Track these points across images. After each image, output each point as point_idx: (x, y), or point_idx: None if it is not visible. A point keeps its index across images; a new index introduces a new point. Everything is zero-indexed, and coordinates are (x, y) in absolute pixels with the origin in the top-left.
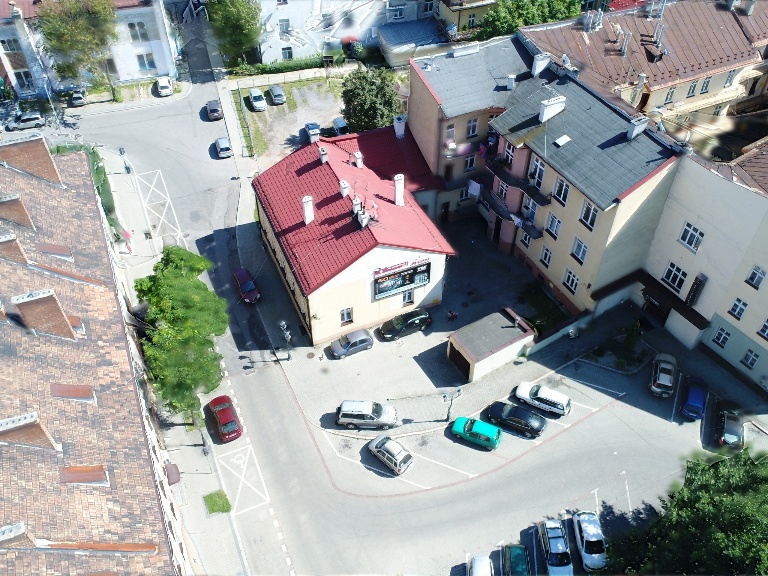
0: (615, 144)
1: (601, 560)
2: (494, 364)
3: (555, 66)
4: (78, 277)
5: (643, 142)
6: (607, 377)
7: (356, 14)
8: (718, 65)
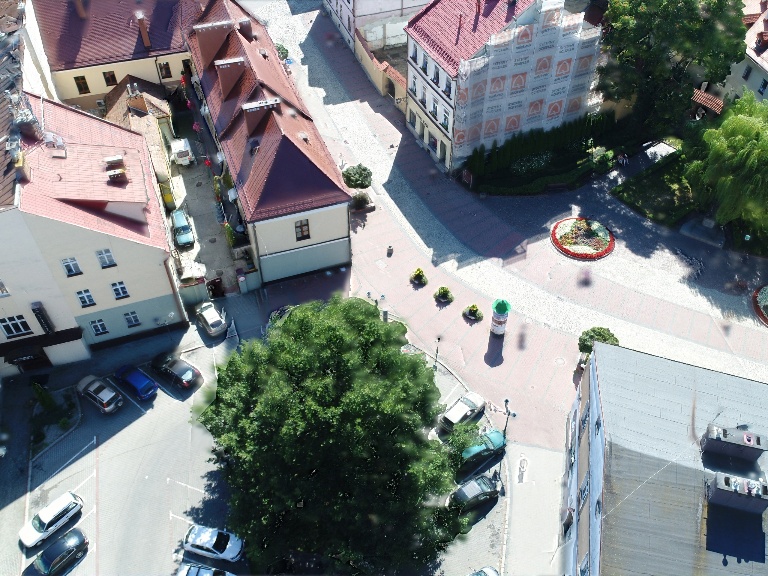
0: None
1: (235, 542)
2: None
3: None
4: None
5: None
6: (69, 444)
7: None
8: None
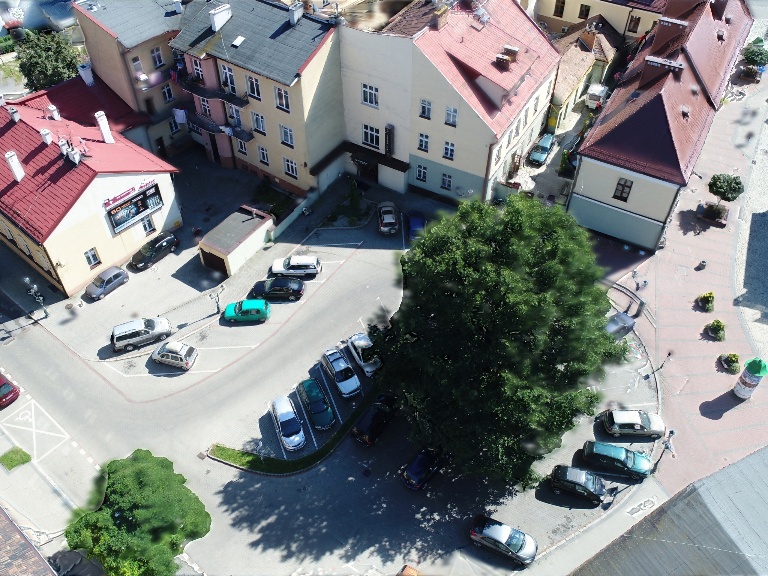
0: (283, 32)
1: (377, 362)
2: (246, 254)
3: None
4: None
5: (305, 24)
6: (345, 235)
7: None
8: None
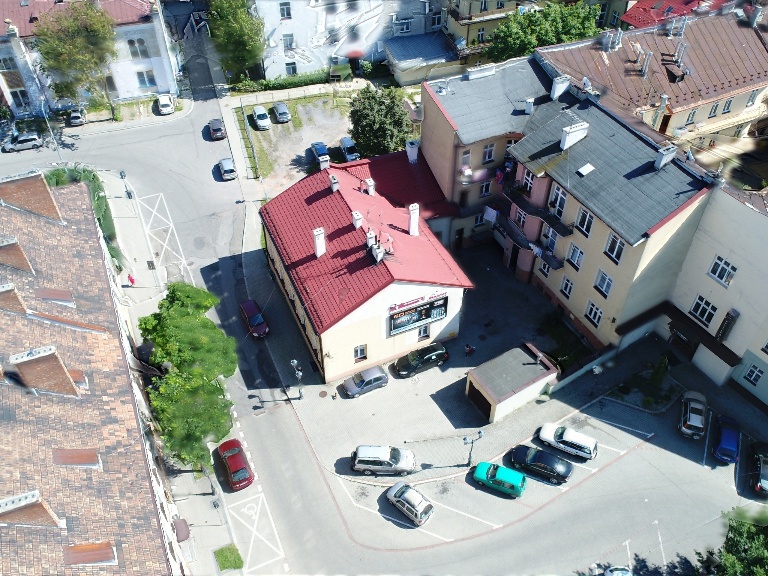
0: (642, 174)
1: None
2: (516, 404)
3: (575, 89)
4: (80, 325)
5: (672, 172)
6: (634, 416)
7: (362, 28)
8: (741, 85)
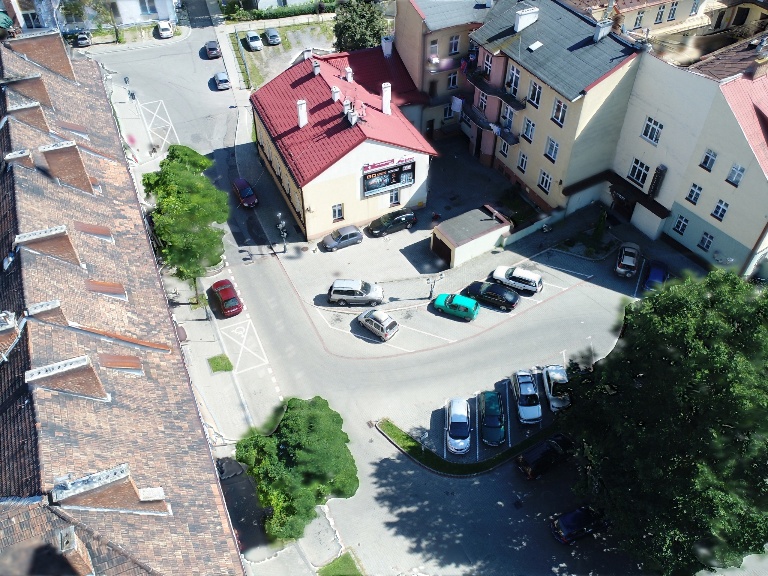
0: (583, 46)
1: (566, 400)
2: (473, 252)
3: None
4: (94, 150)
5: (608, 43)
6: (577, 263)
7: None
8: None
